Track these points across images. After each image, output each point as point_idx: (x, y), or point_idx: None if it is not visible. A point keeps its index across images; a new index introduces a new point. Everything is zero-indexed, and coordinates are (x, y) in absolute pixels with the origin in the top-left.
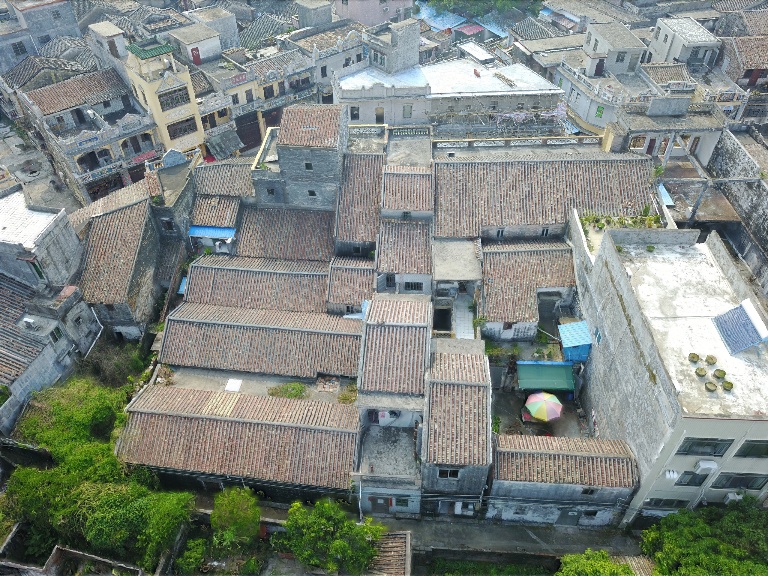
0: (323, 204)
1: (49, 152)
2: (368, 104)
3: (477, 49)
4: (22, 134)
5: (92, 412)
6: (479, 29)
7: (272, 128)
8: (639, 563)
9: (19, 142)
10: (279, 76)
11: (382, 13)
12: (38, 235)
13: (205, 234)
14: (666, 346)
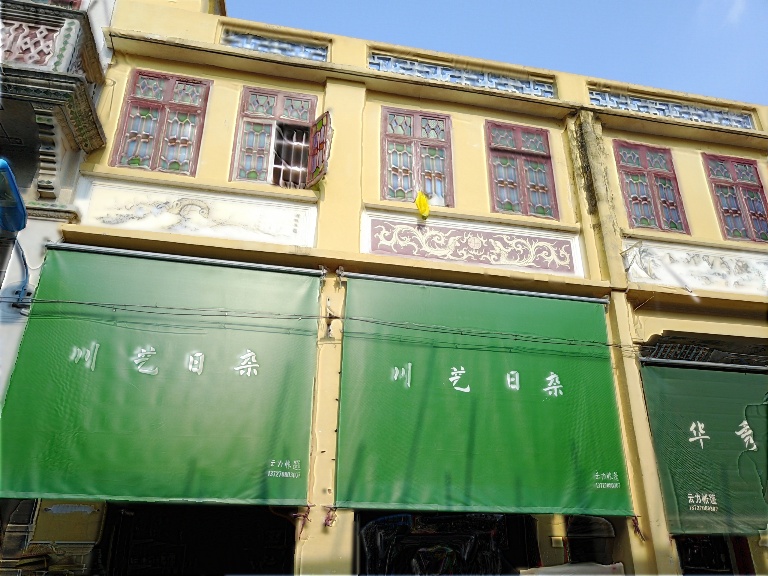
0: None
1: None
2: None
3: None
4: None
5: None
6: None
7: None
8: None
9: None
10: None
11: None
12: None
13: None
14: None
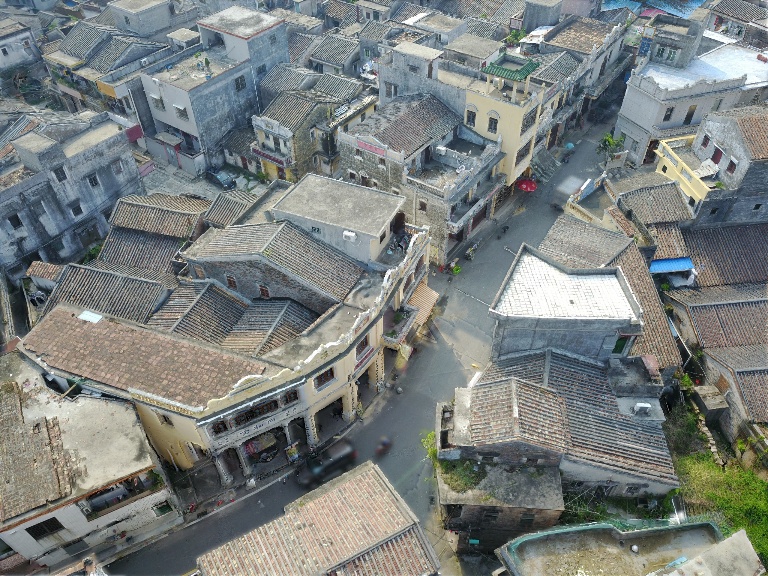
0: (763, 217)
1: None
2: (684, 103)
3: (711, 33)
4: None
5: (764, 496)
6: None
7: (665, 141)
8: None
9: None
10: (570, 83)
11: (588, 5)
12: (636, 304)
13: (662, 269)
14: None
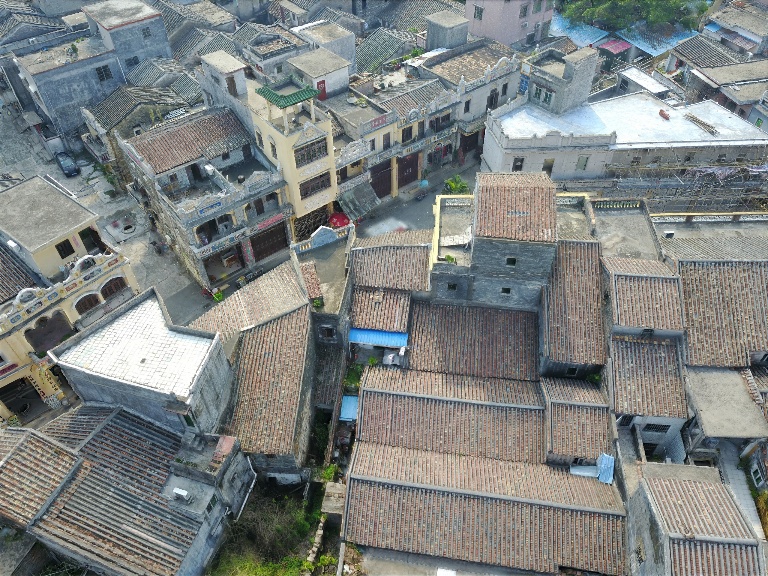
0: (517, 303)
1: (153, 211)
2: (536, 155)
3: (644, 77)
4: (112, 179)
5: None
6: (626, 46)
7: (441, 197)
8: None
9: (106, 186)
10: (420, 115)
11: (520, 29)
12: (193, 378)
13: (370, 340)
14: None
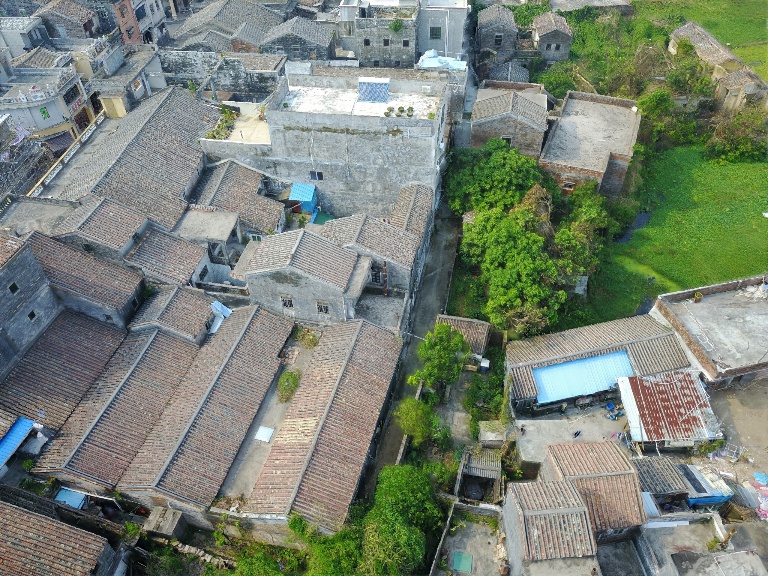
0: (47, 316)
1: None
2: None
3: None
4: None
5: (269, 569)
6: None
7: None
8: (468, 216)
9: None
10: None
11: None
12: None
13: (4, 456)
14: None
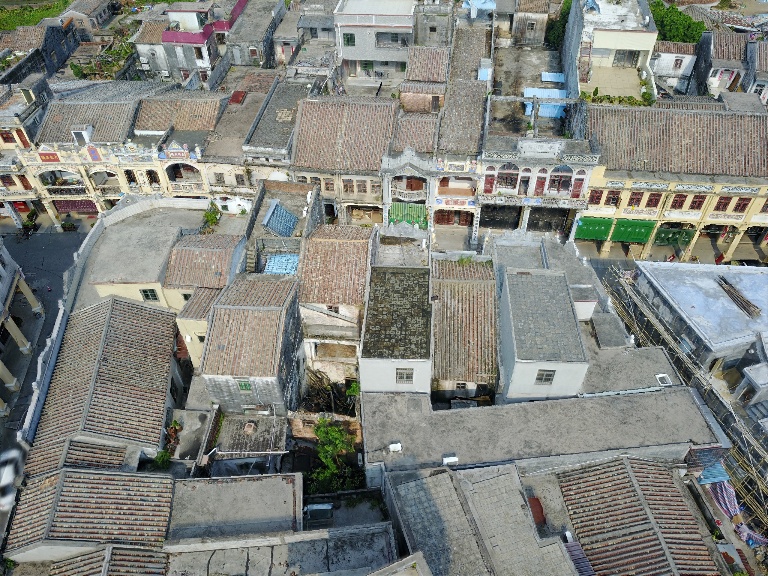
0: None
1: None
2: None
3: None
4: None
5: None
6: None
7: None
8: None
9: None
10: None
11: None
12: None
13: None
14: (630, 8)
